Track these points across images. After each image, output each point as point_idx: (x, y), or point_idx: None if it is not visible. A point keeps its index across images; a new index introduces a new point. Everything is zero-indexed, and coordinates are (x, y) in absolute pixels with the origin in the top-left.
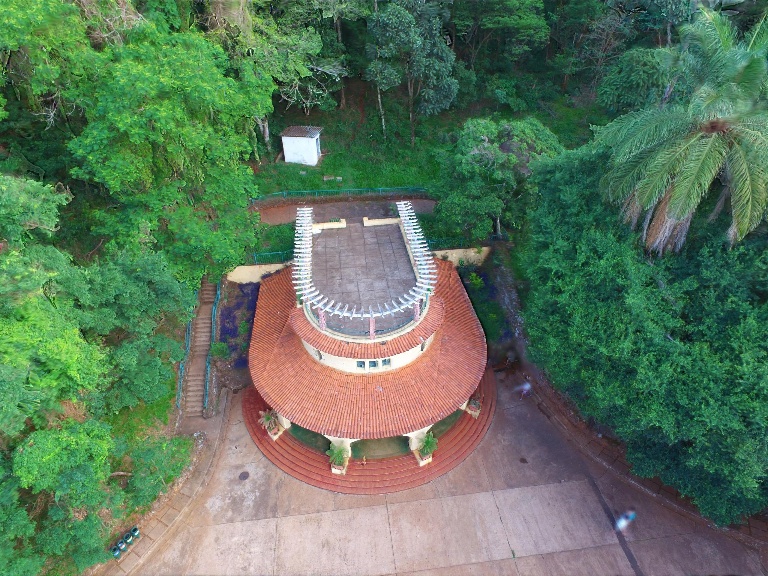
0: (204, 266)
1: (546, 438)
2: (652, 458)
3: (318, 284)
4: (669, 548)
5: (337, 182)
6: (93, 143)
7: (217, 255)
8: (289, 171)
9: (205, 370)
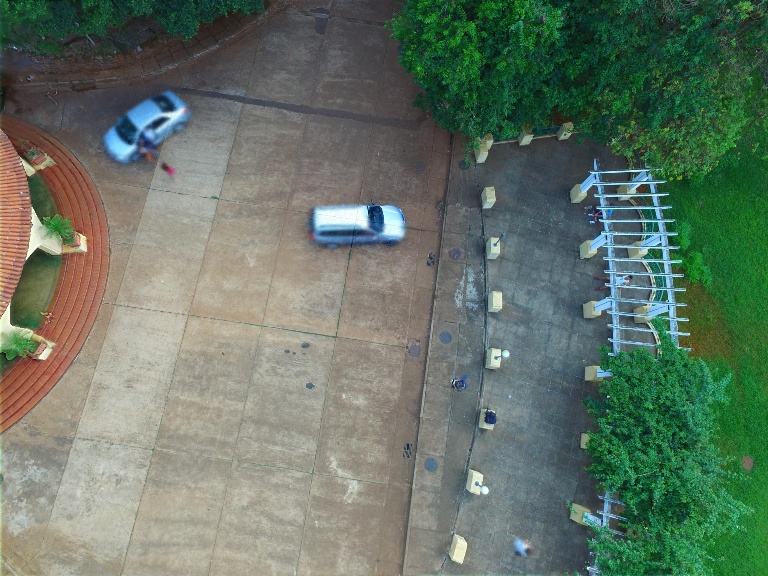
0: None
1: (117, 105)
2: (181, 8)
3: None
4: (262, 67)
5: None
6: None
7: None
8: None
9: None
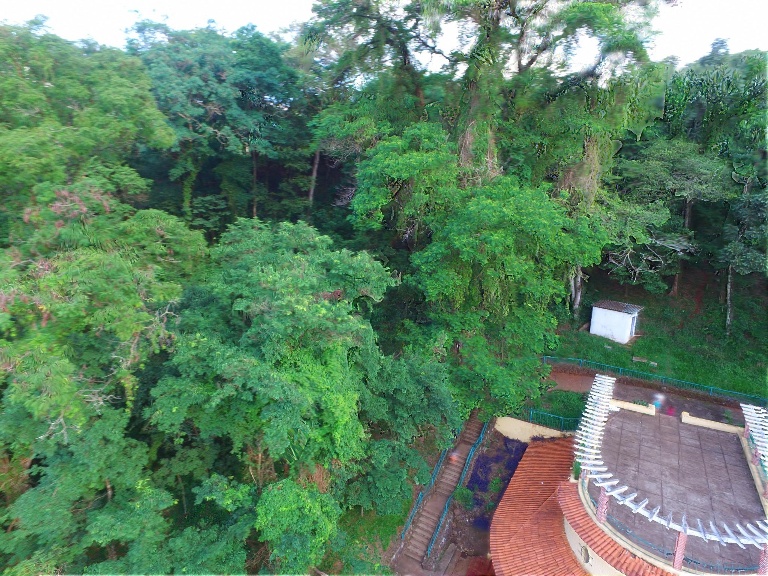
0: (479, 398)
1: None
2: None
3: (604, 465)
4: None
5: (650, 366)
6: (430, 255)
7: (496, 389)
8: (592, 342)
9: (442, 511)
